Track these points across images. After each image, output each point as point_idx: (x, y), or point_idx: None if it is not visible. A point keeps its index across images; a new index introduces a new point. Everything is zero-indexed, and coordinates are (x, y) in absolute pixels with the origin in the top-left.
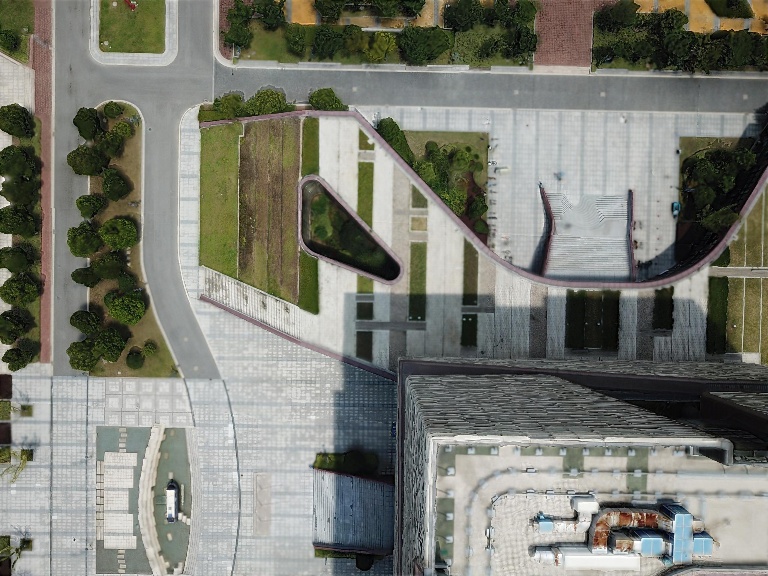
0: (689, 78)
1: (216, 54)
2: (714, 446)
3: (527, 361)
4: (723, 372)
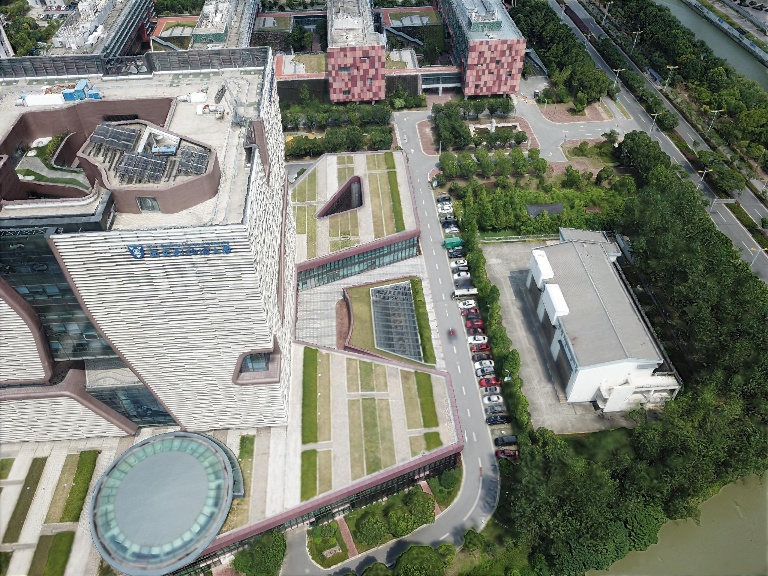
0: (286, 165)
1: None
2: (97, 55)
3: None
4: None
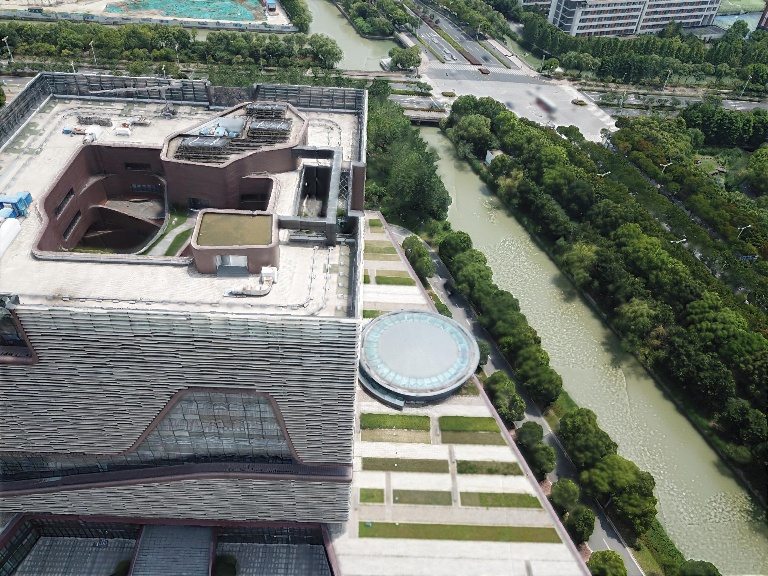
0: None
1: None
2: None
3: None
4: None
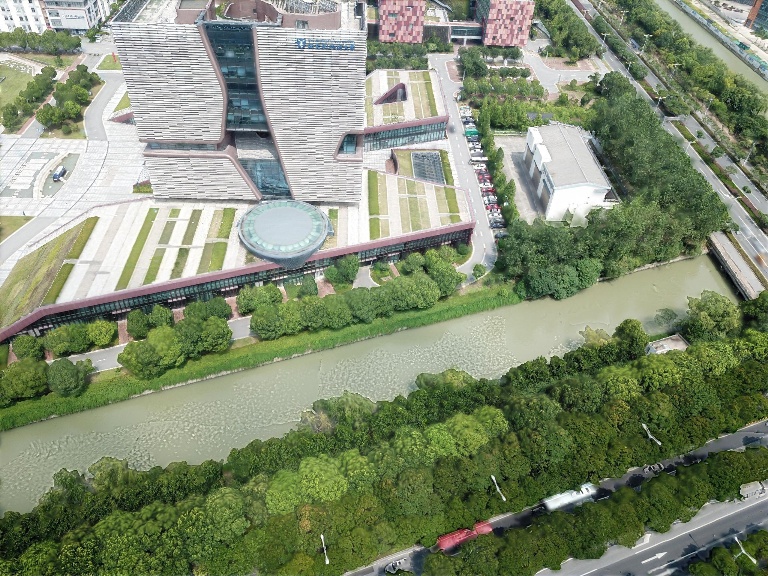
0: None
1: None
2: None
3: None
4: None
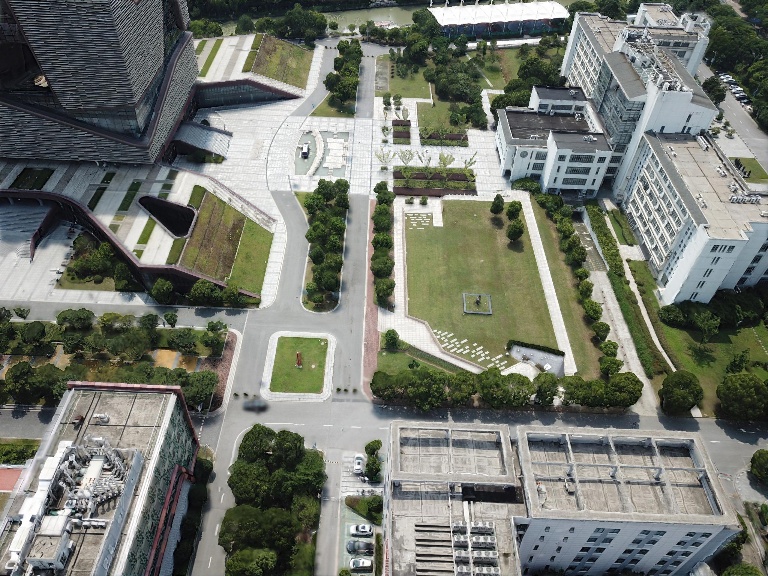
0: None
1: (241, 336)
2: None
3: (78, 153)
4: None
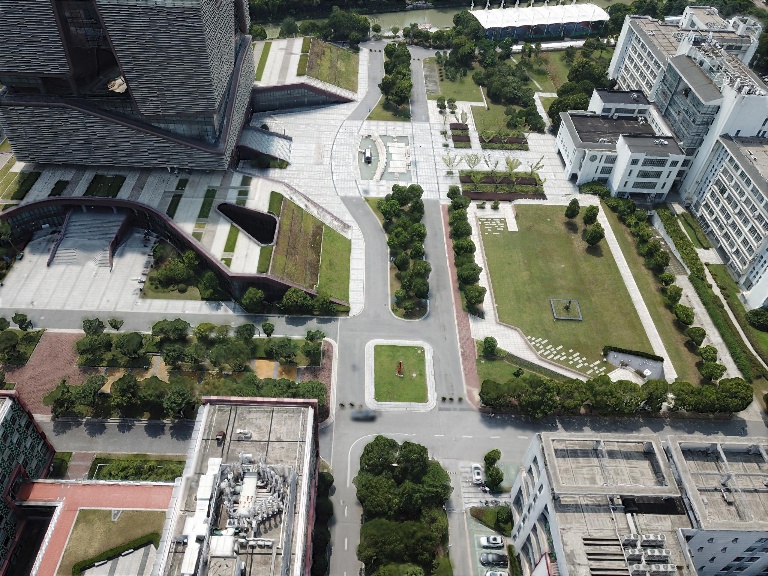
0: None
1: (336, 345)
2: None
3: (152, 159)
4: (46, 128)
